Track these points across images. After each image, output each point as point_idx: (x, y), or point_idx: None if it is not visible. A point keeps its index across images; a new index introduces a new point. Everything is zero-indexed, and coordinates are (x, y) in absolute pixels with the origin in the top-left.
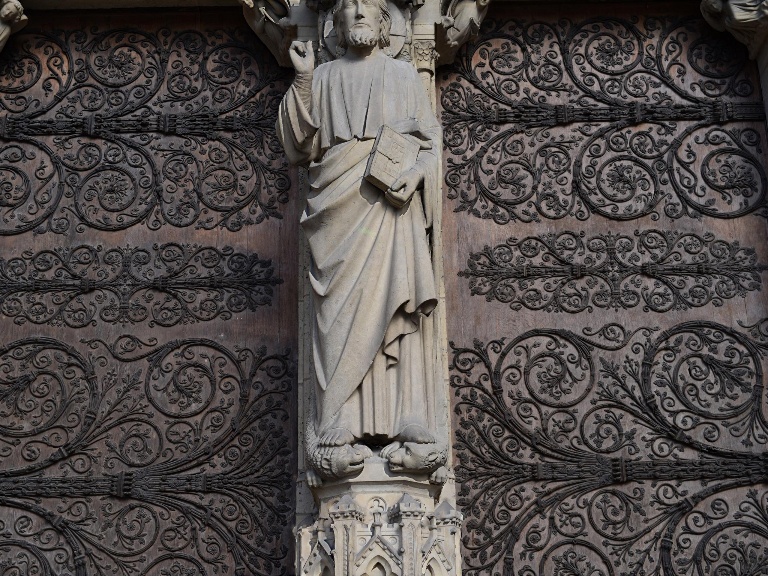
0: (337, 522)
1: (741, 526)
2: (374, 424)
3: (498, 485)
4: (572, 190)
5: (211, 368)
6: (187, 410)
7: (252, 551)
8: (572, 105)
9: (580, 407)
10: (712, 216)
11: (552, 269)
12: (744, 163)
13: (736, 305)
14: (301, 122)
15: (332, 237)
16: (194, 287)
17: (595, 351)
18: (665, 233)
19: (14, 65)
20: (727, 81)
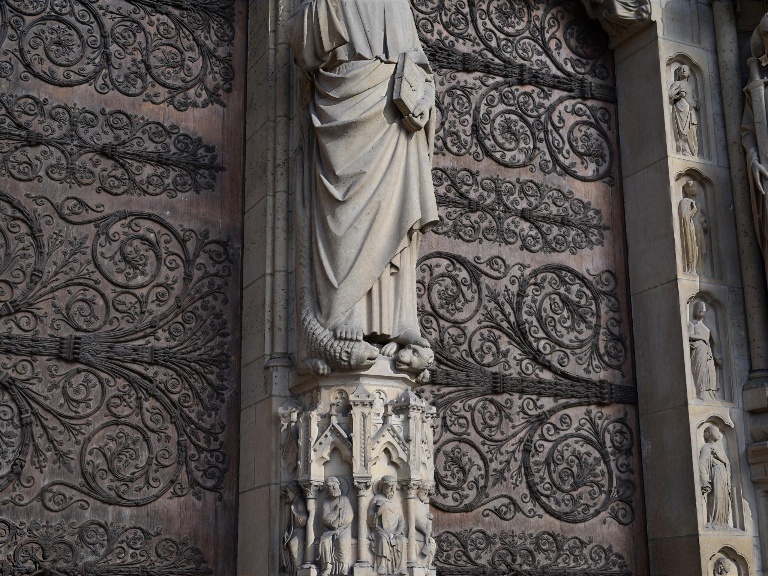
0: (356, 409)
1: (580, 438)
2: (381, 325)
3: None
4: (472, 132)
5: (157, 243)
6: (133, 281)
7: (193, 424)
8: (476, 55)
9: (469, 325)
10: (574, 177)
11: (454, 200)
12: (598, 136)
13: (586, 255)
14: (332, 32)
15: (354, 148)
16: (142, 160)
17: (483, 278)
18: (539, 185)
19: None
20: (590, 62)
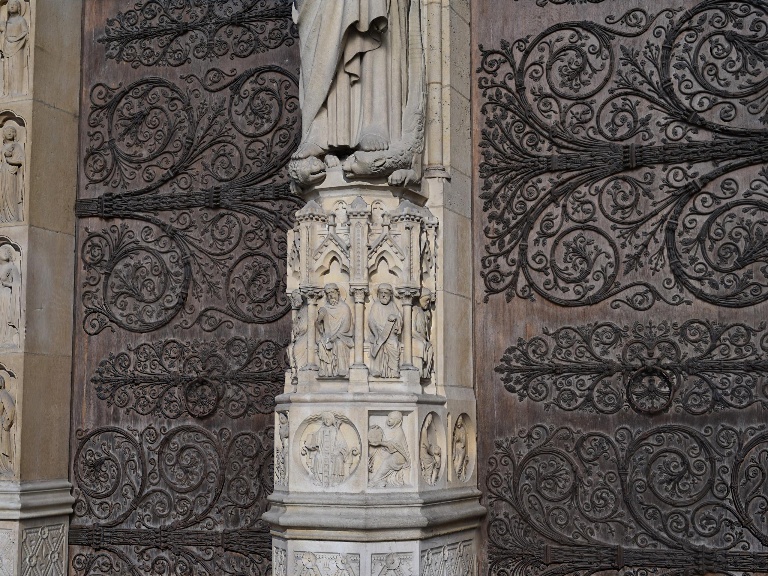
0: (301, 224)
1: (749, 204)
2: (337, 137)
3: (517, 178)
4: None
5: (278, 91)
6: (261, 130)
7: None
8: None
9: (598, 97)
10: None
11: None
12: None
13: None
14: None
15: None
16: (264, 19)
17: (616, 39)
18: None
19: None
20: None
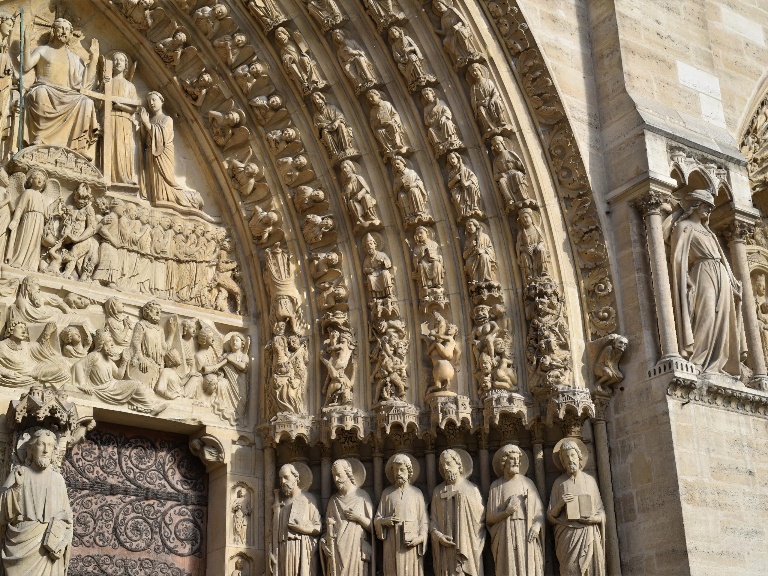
0: None
1: None
2: None
3: None
4: (113, 532)
5: None
6: None
7: None
8: (119, 485)
9: None
10: (176, 554)
11: (97, 575)
12: (194, 527)
13: None
14: (14, 509)
15: (21, 571)
16: None
17: None
18: (153, 561)
19: None
20: (194, 482)
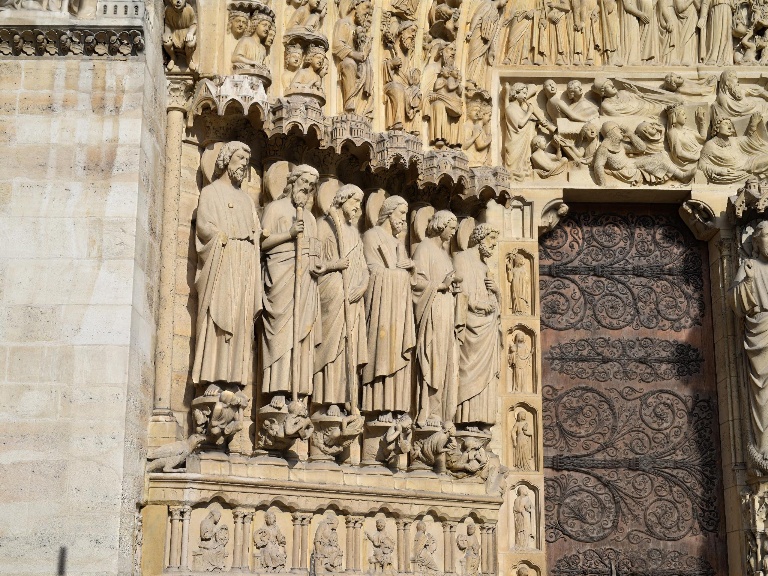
0: None
1: None
2: None
3: None
4: None
5: (672, 405)
6: (662, 426)
7: (700, 498)
8: None
9: None
10: None
11: None
12: None
13: None
14: (749, 301)
15: (766, 360)
16: (660, 362)
17: None
18: None
19: (553, 233)
20: None
